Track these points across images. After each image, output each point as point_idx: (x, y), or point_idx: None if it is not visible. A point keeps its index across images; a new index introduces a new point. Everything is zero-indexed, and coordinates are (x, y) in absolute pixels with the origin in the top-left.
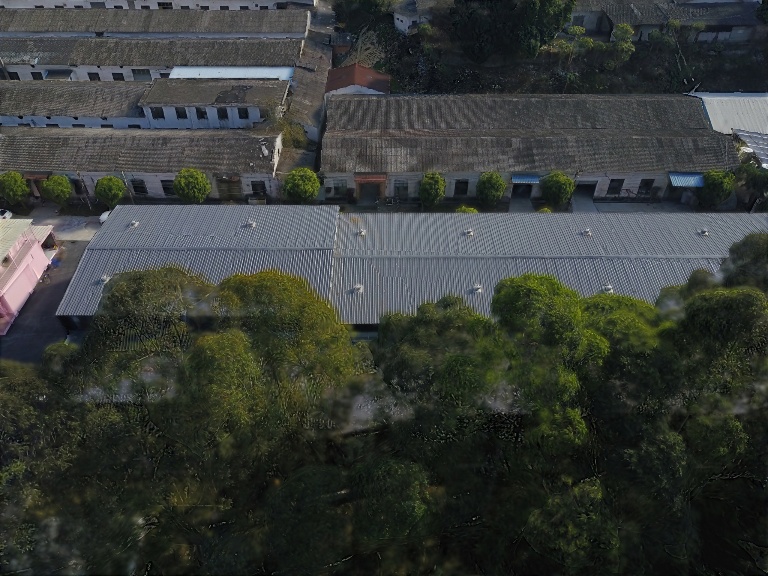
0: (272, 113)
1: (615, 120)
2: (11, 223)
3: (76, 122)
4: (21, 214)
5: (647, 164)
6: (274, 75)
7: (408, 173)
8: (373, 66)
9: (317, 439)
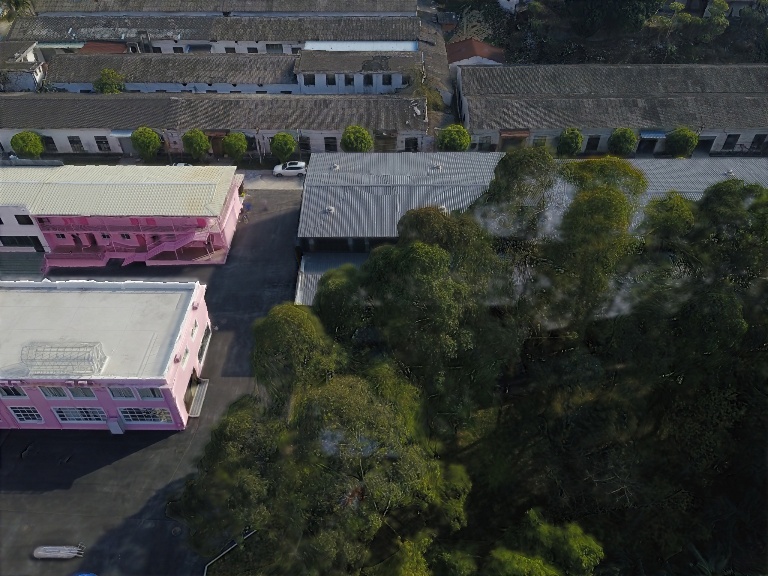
0: (416, 79)
1: (722, 85)
2: (220, 169)
3: (234, 89)
4: None
5: (761, 121)
6: (400, 48)
7: (548, 130)
8: (482, 41)
9: (633, 289)
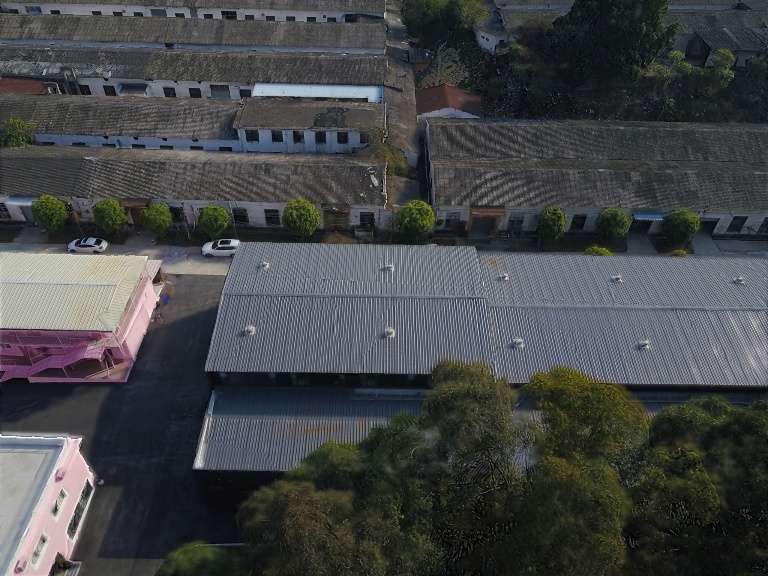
0: (376, 139)
1: (727, 152)
2: (127, 260)
3: (164, 143)
4: (116, 243)
5: None
6: (362, 95)
7: (526, 207)
8: (457, 86)
9: (625, 562)
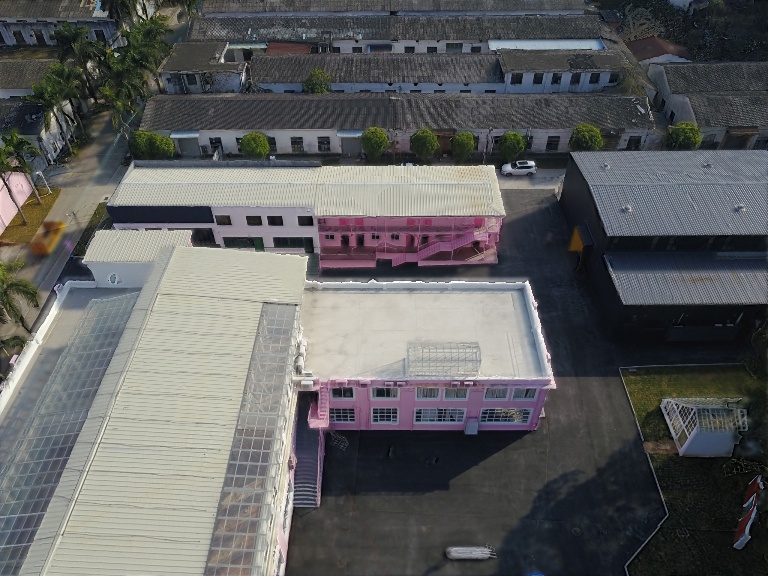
0: (628, 77)
1: None
2: (481, 168)
3: (439, 88)
4: None
5: None
6: (586, 47)
7: None
8: None
9: None
